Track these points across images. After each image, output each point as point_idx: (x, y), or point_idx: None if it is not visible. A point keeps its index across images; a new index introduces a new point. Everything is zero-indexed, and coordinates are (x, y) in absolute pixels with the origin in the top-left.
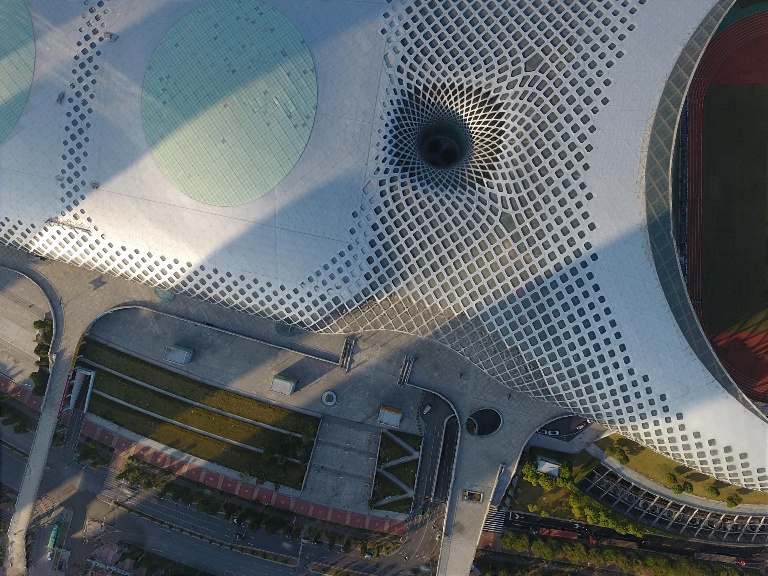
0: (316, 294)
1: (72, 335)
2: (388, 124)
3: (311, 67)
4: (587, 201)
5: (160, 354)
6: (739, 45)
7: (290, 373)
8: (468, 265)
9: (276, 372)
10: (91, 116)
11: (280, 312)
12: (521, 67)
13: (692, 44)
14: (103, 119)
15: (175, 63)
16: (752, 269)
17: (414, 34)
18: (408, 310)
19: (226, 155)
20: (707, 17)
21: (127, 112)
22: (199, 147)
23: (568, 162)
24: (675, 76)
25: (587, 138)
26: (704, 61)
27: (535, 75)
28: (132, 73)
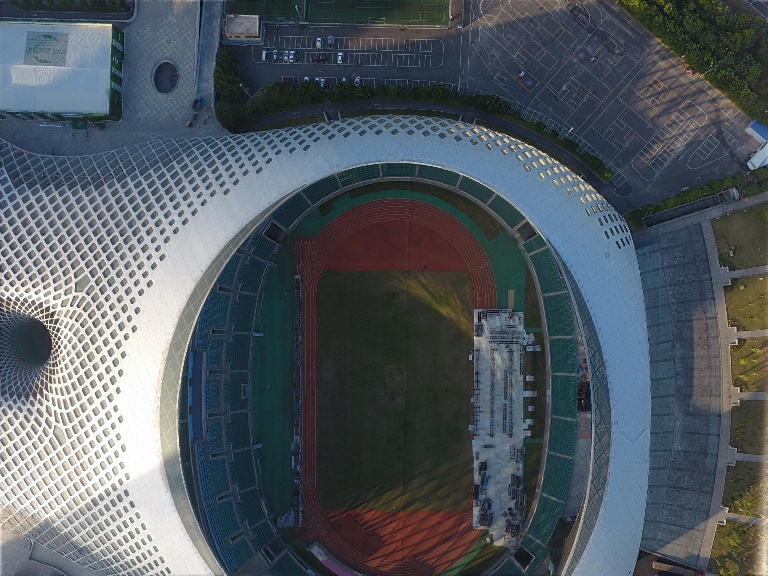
0: None
1: None
2: None
3: None
4: (119, 423)
5: None
6: (349, 234)
7: None
8: (31, 472)
9: None
10: None
11: None
12: (72, 287)
13: (203, 282)
14: None
15: None
16: (363, 448)
17: None
18: None
19: None
20: (219, 255)
21: None
22: None
23: (105, 384)
24: (187, 312)
25: (119, 363)
26: (317, 248)
27: (83, 296)
28: None
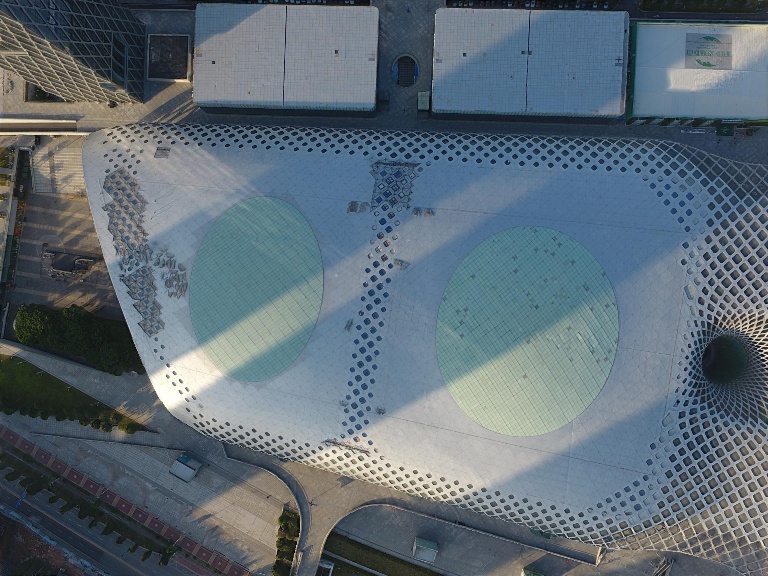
0: (602, 518)
1: (318, 532)
2: (688, 356)
3: (613, 300)
4: None
5: (402, 546)
6: None
7: (536, 567)
8: None
9: (522, 566)
10: (380, 344)
11: (557, 529)
12: None
13: None
14: (393, 347)
15: (473, 296)
16: None
17: (714, 264)
18: (697, 536)
19: (526, 390)
20: None
21: (419, 342)
22: (498, 381)
23: None
24: None
25: None
26: None
27: None
28: (425, 302)
